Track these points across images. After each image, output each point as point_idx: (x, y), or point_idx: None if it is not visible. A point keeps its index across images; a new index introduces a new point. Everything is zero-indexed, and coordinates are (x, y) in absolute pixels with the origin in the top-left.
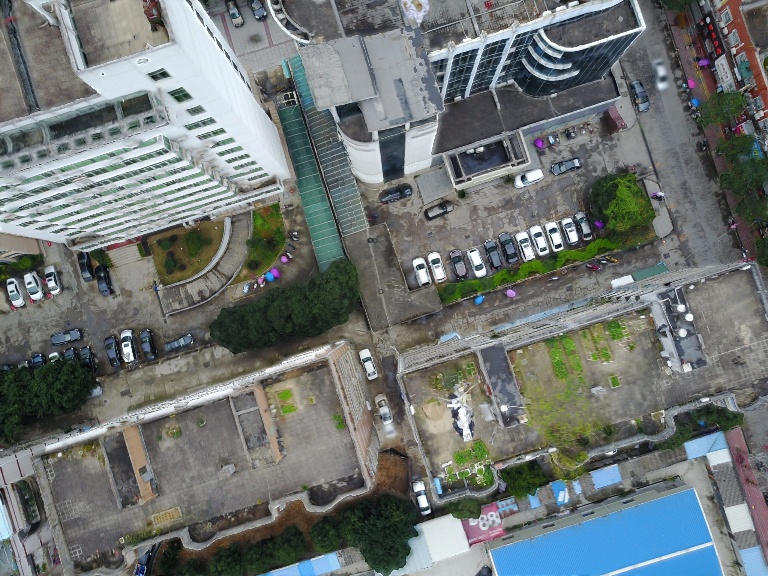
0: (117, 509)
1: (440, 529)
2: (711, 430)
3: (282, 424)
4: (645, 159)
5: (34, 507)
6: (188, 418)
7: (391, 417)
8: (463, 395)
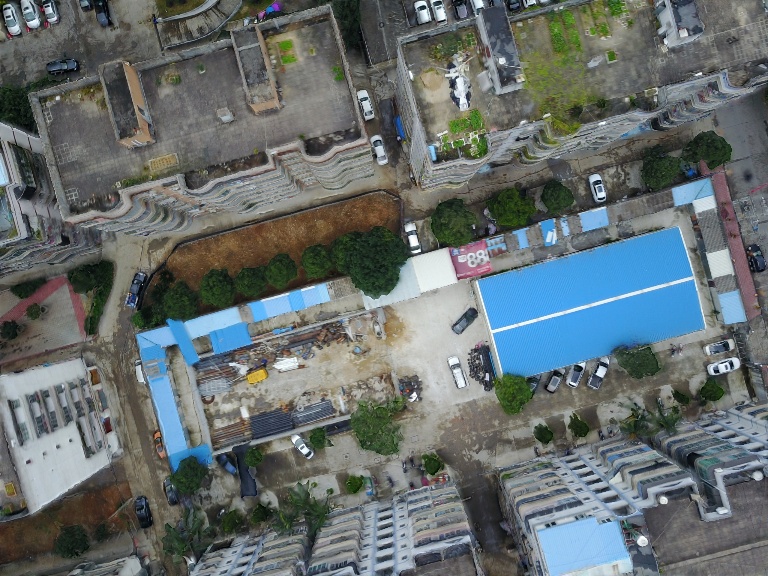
0: (114, 154)
1: (429, 263)
2: (699, 176)
3: (282, 75)
4: None
5: (30, 173)
6: (188, 66)
7: (386, 158)
8: (462, 65)
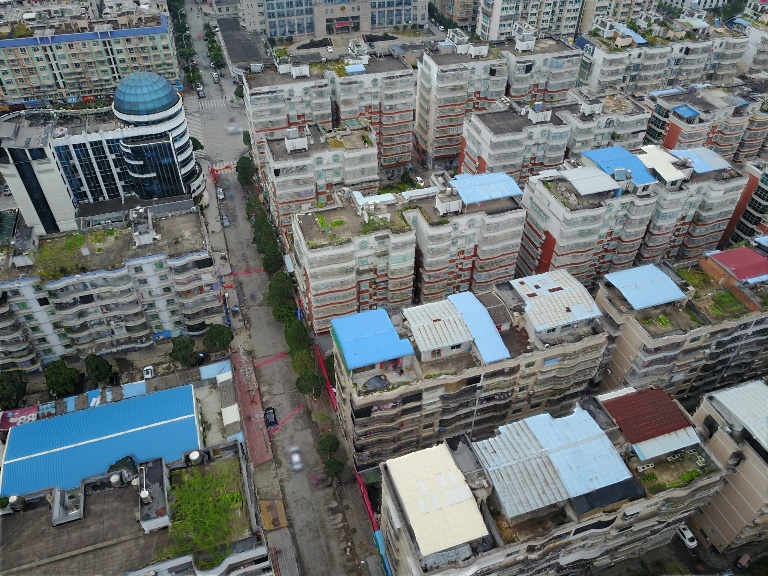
0: None
1: None
2: None
3: None
4: (223, 245)
5: None
6: None
7: None
8: (2, 257)
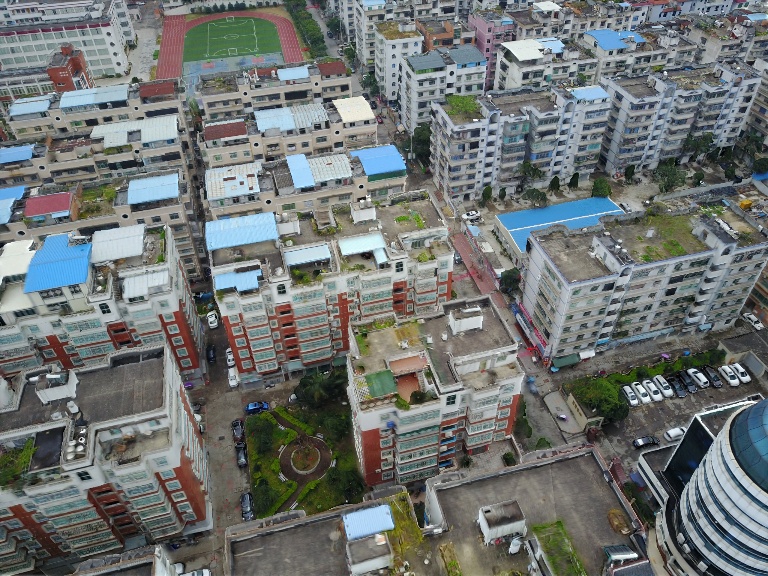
0: None
1: None
2: None
3: None
4: None
5: None
6: None
7: None
8: None
